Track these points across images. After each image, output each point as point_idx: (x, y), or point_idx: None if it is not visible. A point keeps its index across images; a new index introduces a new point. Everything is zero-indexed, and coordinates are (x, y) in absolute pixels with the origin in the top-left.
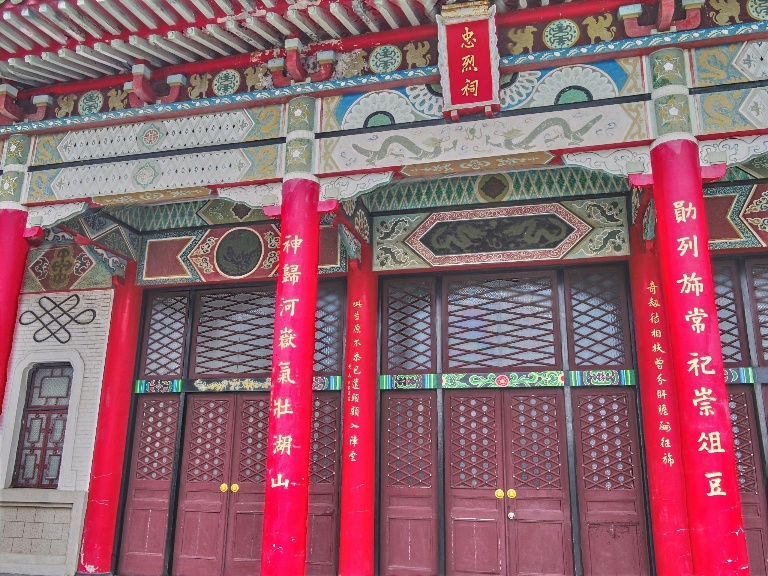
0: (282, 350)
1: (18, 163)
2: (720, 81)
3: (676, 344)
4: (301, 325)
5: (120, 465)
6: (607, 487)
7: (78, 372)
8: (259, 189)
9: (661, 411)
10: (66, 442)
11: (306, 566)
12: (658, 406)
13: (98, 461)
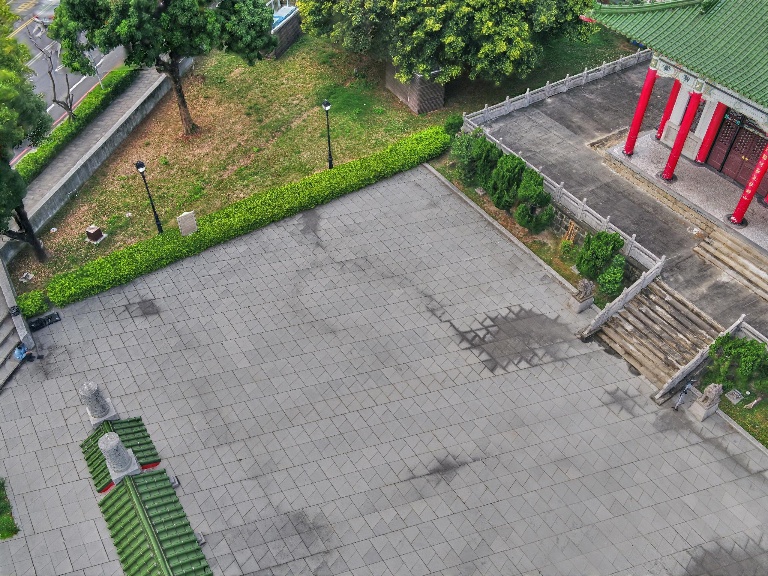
0: (756, 173)
1: (703, 80)
2: None
3: None
4: (763, 169)
5: (714, 137)
6: None
7: (708, 103)
8: (767, 127)
9: None
10: (699, 123)
11: (759, 189)
12: None
13: (708, 135)
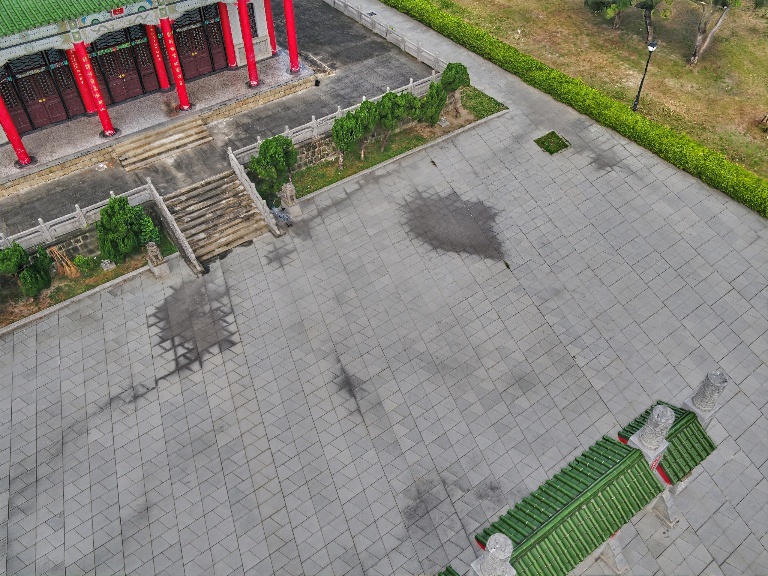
0: None
1: None
2: (171, 2)
3: (171, 60)
4: None
5: None
6: (145, 66)
7: None
8: None
9: (156, 49)
10: None
11: None
12: (155, 48)
13: None
